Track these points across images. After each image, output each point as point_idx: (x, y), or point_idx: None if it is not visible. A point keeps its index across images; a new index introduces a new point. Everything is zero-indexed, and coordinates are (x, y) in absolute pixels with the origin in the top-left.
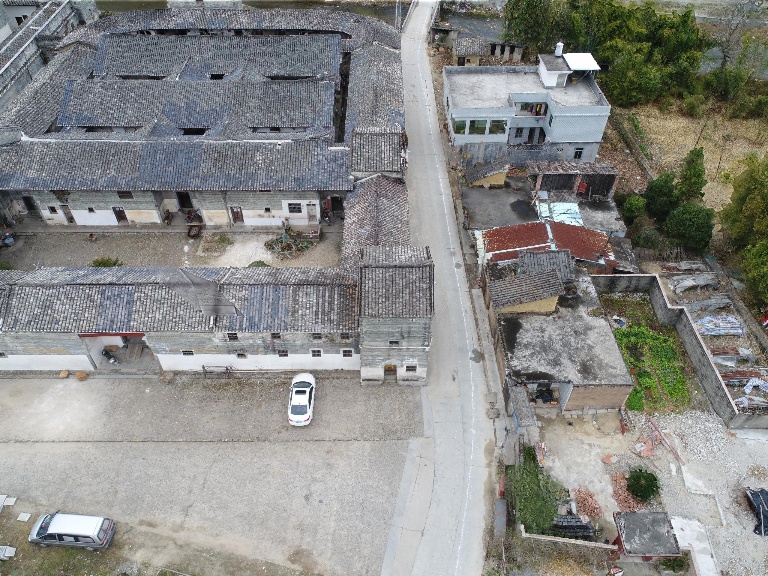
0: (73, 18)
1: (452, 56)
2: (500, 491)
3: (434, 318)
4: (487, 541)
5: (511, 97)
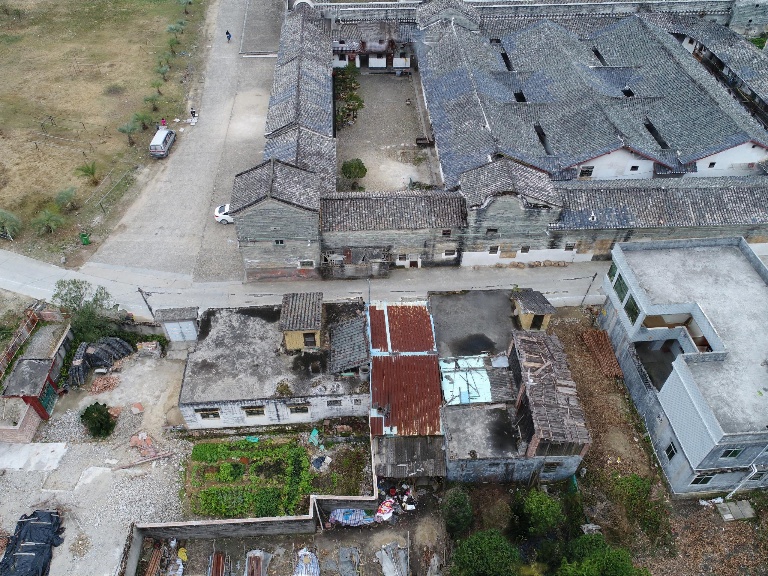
0: (722, 17)
1: None
2: None
3: (322, 289)
4: None
5: (682, 302)
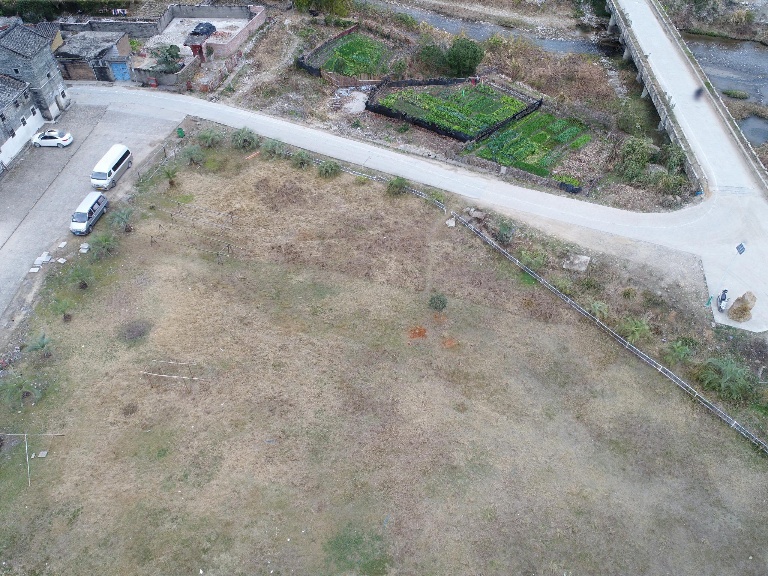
0: None
1: None
2: (155, 80)
3: None
4: None
5: None
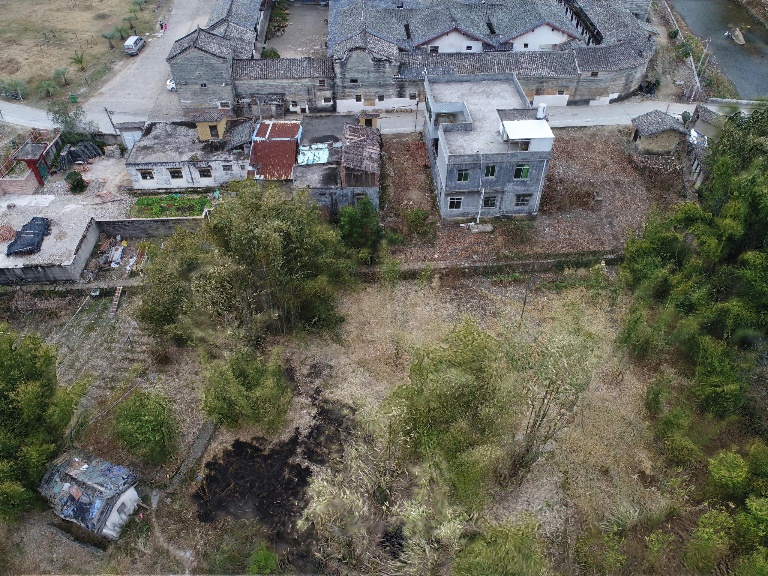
0: None
1: None
2: None
3: None
4: None
5: None
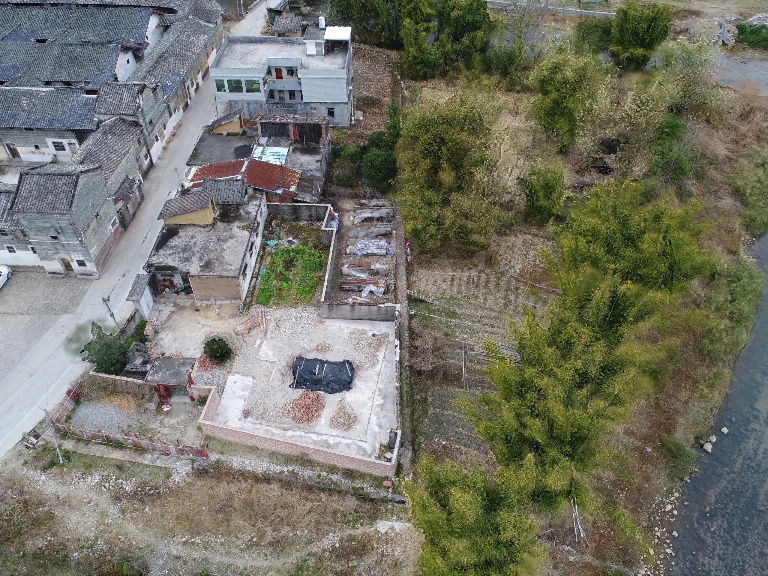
0: None
1: None
2: None
3: (135, 233)
4: (78, 382)
5: (265, 61)
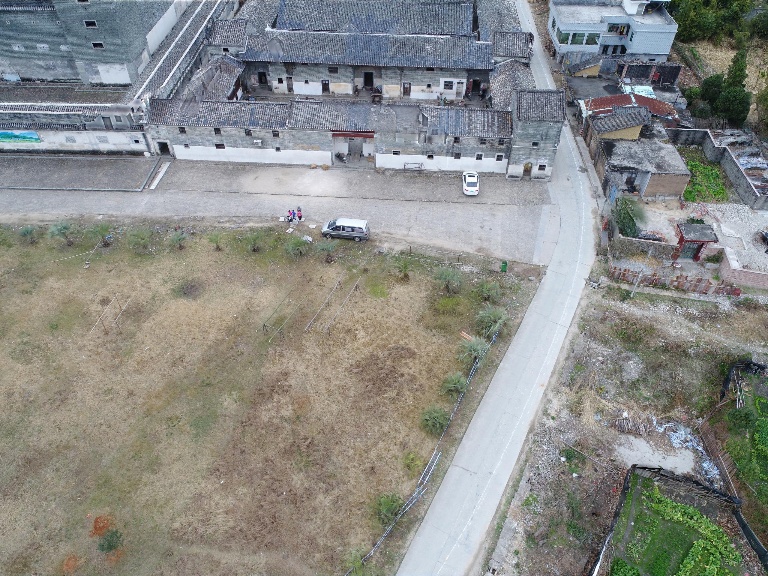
0: None
1: (548, 3)
2: (605, 223)
3: None
4: (597, 248)
5: (604, 18)
